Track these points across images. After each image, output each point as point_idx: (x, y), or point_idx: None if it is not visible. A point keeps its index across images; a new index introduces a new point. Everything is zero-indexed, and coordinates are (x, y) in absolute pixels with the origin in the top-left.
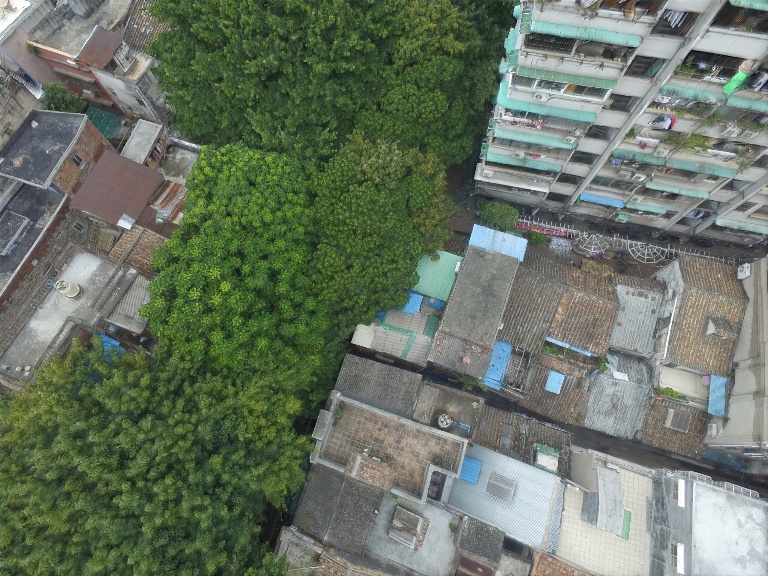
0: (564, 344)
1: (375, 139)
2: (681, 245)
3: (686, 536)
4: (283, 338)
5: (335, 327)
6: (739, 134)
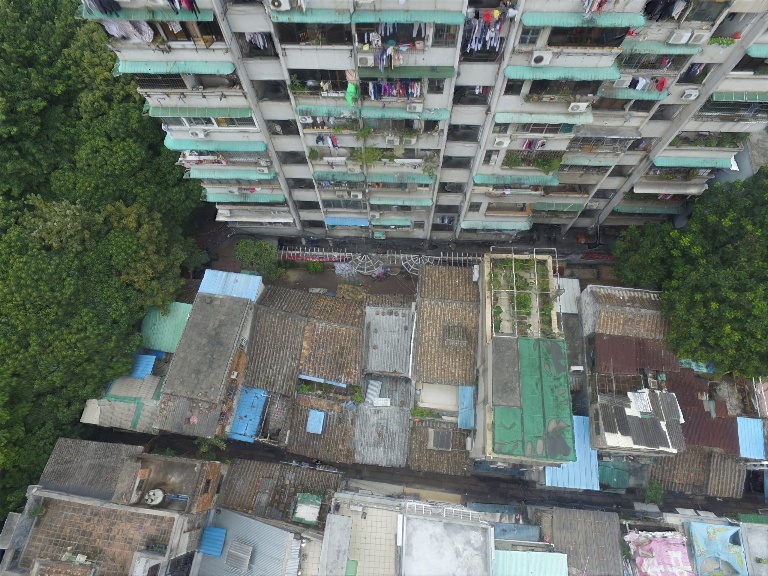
0: (318, 379)
1: (73, 199)
2: (453, 251)
3: None
4: None
5: (54, 409)
6: (400, 142)
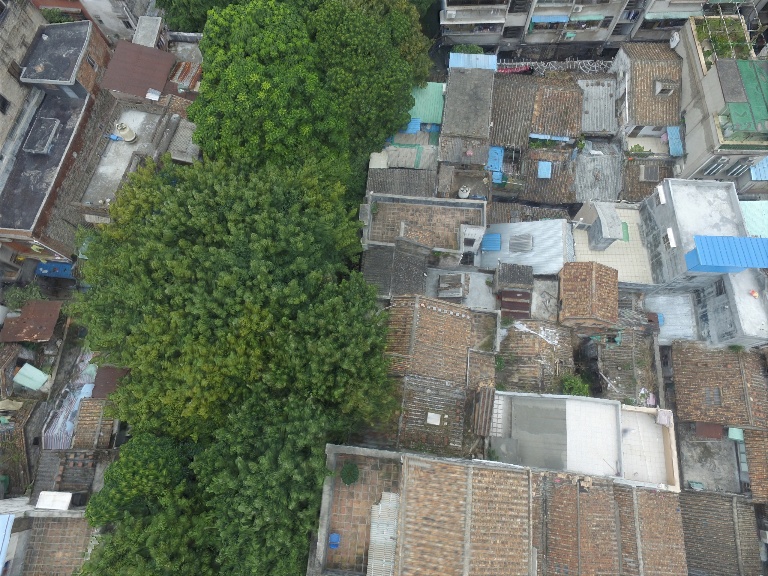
0: (545, 136)
1: None
2: None
3: (672, 220)
4: (319, 138)
5: (353, 155)
6: None
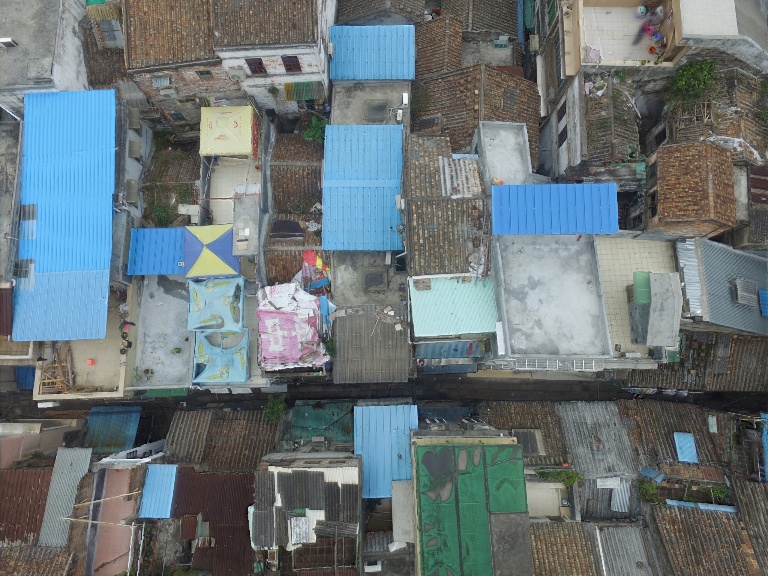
0: (708, 508)
1: None
2: None
3: None
4: None
5: None
6: None
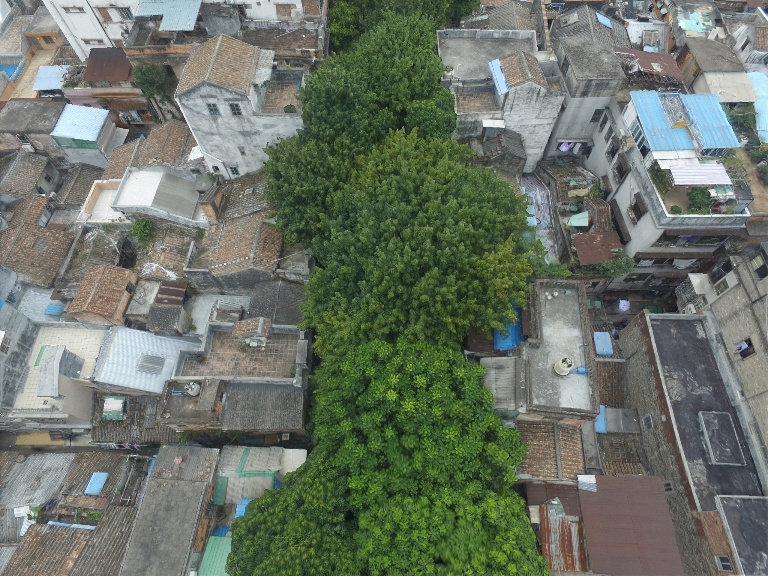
0: (77, 527)
1: None
2: None
3: None
4: None
5: None
6: None
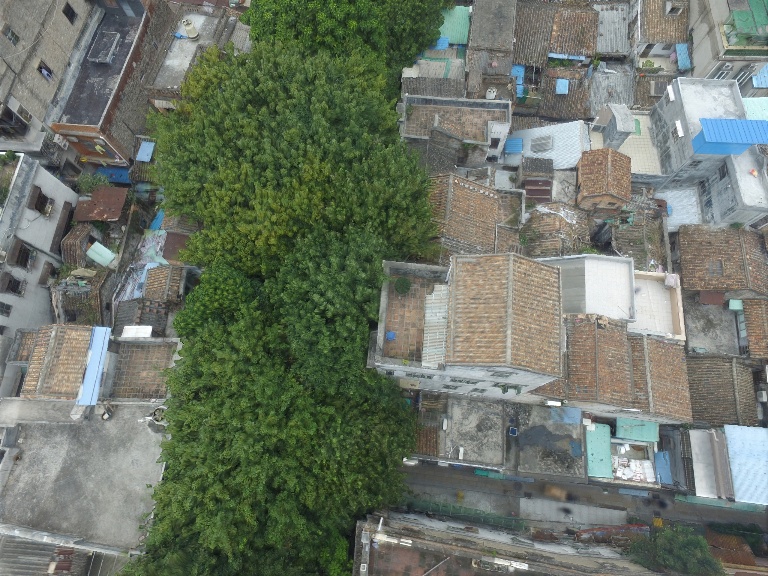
0: (563, 56)
1: None
2: None
3: (680, 113)
4: (362, 37)
5: None
6: None
